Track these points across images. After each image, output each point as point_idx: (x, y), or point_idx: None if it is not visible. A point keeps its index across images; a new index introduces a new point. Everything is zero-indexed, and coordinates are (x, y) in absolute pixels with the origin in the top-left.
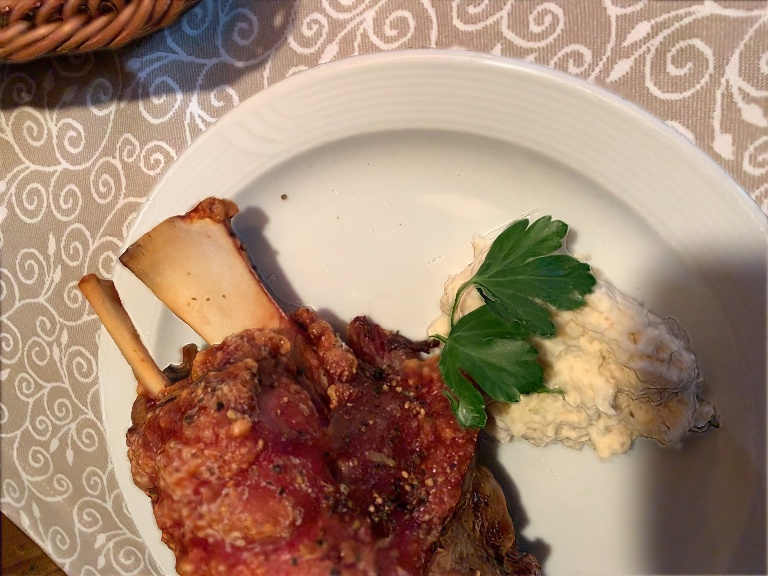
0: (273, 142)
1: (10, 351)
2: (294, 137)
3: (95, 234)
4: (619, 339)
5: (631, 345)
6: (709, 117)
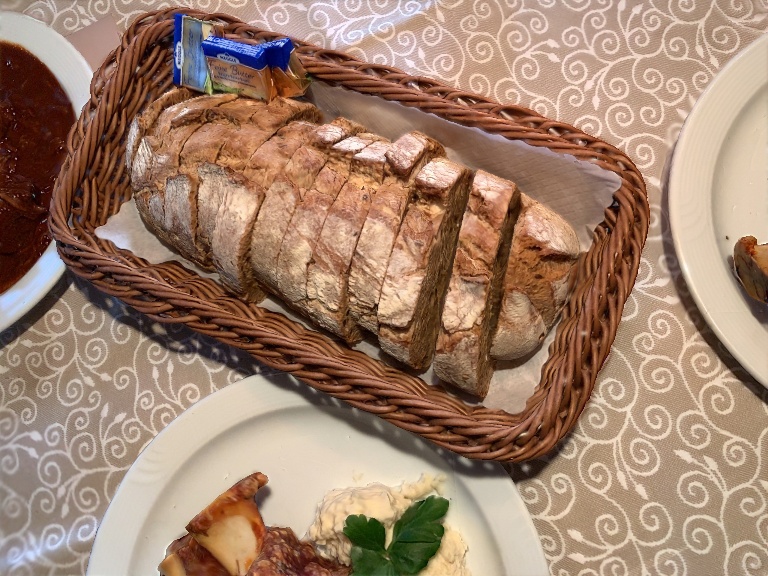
0: (700, 218)
1: (762, 563)
2: (702, 205)
3: (693, 405)
4: None
5: None
6: (754, 33)
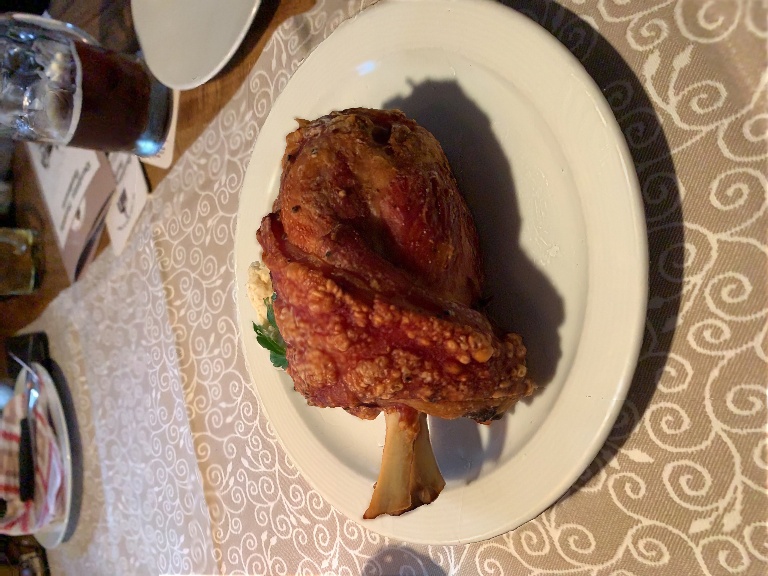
0: None
1: None
2: (367, 491)
3: (583, 574)
4: (257, 300)
5: (253, 295)
6: None
